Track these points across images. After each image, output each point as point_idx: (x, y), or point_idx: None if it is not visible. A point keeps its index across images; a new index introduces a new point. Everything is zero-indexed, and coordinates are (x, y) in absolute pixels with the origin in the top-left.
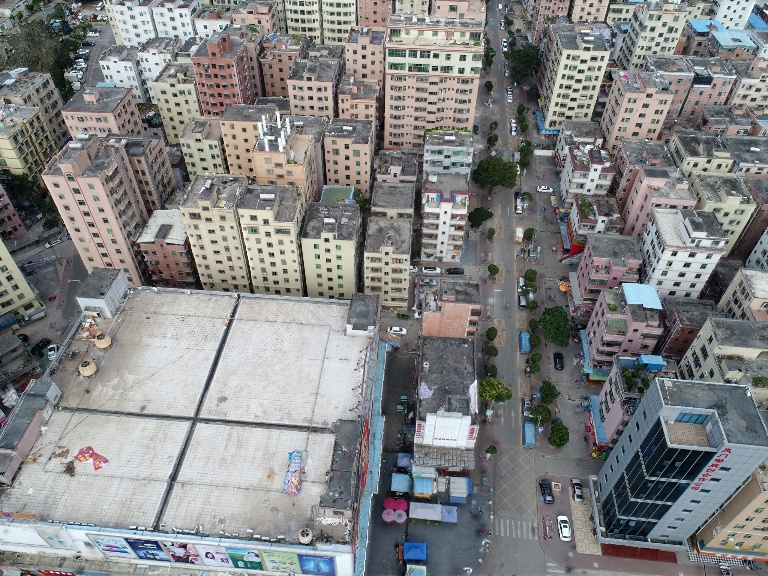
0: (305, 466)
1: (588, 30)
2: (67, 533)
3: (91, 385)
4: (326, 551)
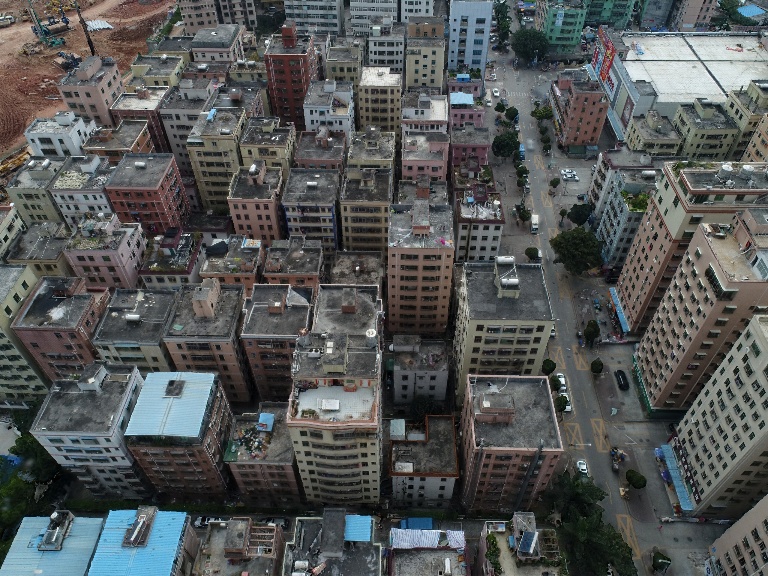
0: None
1: (506, 279)
2: None
3: None
4: None
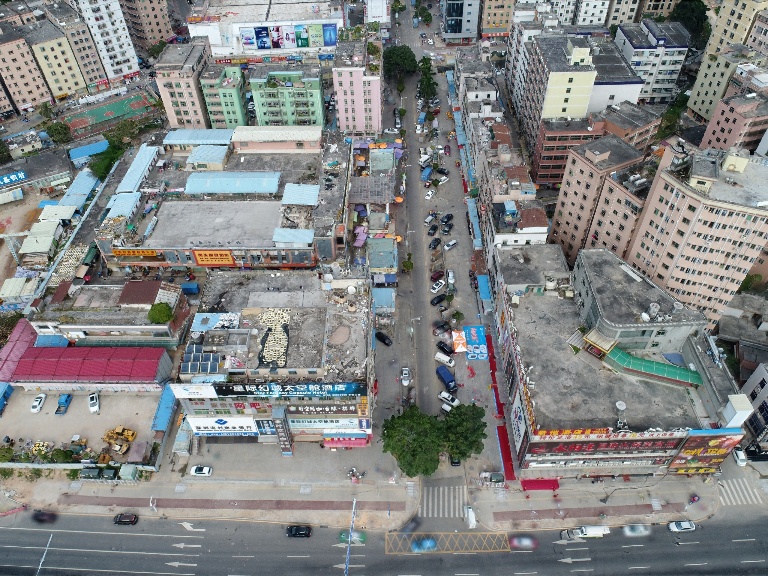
0: (320, 8)
1: None
2: (232, 27)
3: (221, 1)
4: (333, 18)
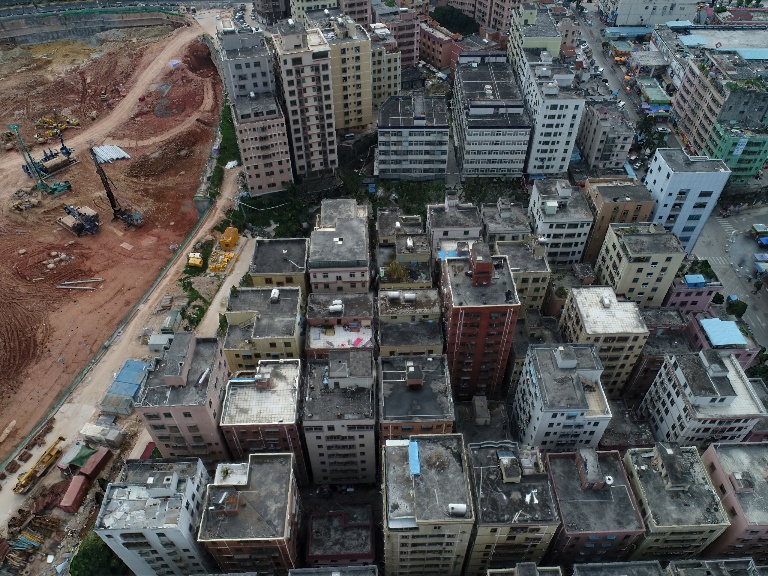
0: None
1: None
2: None
3: None
4: None
